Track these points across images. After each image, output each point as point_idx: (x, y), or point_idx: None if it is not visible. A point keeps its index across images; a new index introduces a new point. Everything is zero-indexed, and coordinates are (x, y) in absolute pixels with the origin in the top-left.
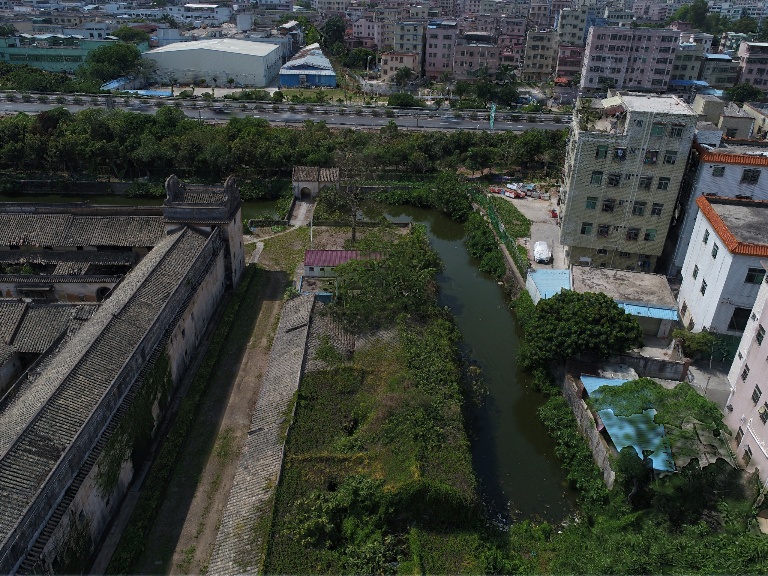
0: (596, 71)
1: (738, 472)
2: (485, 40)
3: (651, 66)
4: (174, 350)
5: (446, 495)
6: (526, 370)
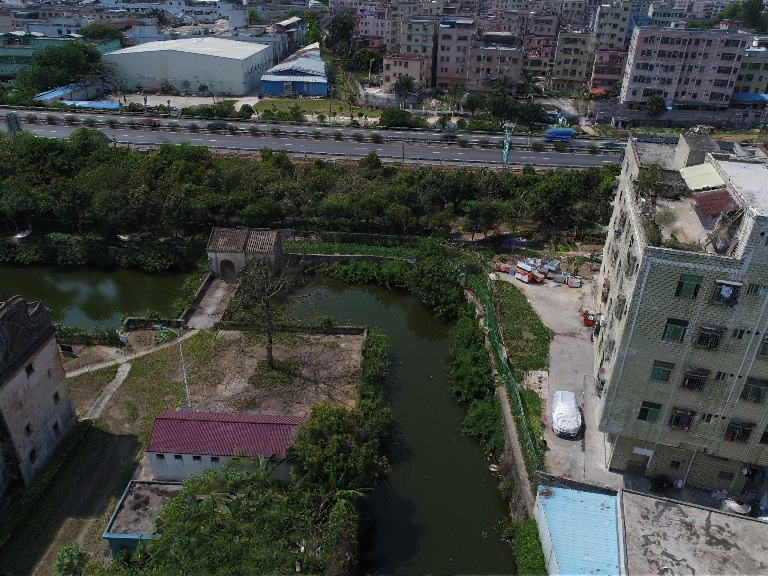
0: (641, 81)
1: None
2: (508, 41)
3: (710, 76)
4: None
5: None
6: None
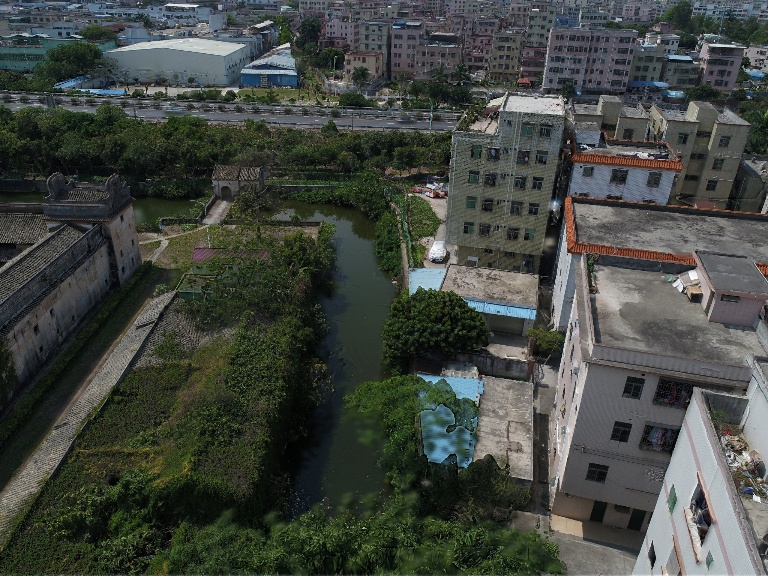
0: (556, 72)
1: (490, 468)
2: (451, 40)
3: (610, 67)
4: (20, 346)
5: (216, 489)
6: (388, 368)
